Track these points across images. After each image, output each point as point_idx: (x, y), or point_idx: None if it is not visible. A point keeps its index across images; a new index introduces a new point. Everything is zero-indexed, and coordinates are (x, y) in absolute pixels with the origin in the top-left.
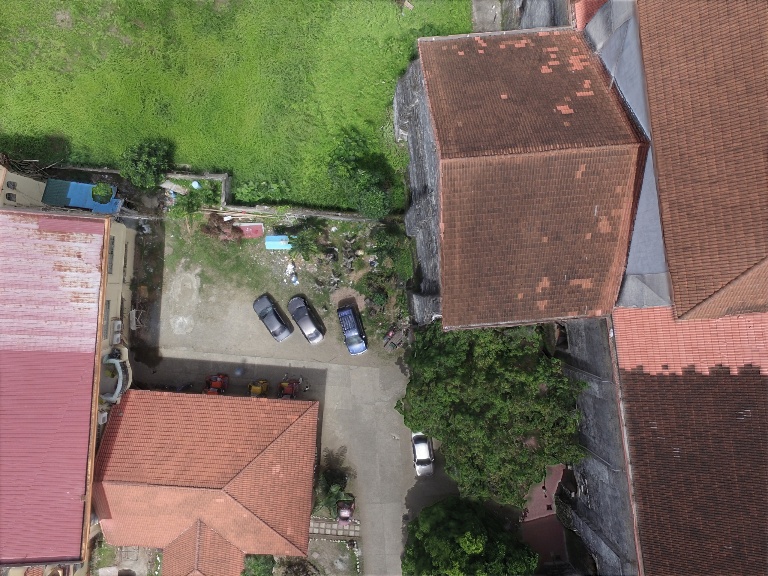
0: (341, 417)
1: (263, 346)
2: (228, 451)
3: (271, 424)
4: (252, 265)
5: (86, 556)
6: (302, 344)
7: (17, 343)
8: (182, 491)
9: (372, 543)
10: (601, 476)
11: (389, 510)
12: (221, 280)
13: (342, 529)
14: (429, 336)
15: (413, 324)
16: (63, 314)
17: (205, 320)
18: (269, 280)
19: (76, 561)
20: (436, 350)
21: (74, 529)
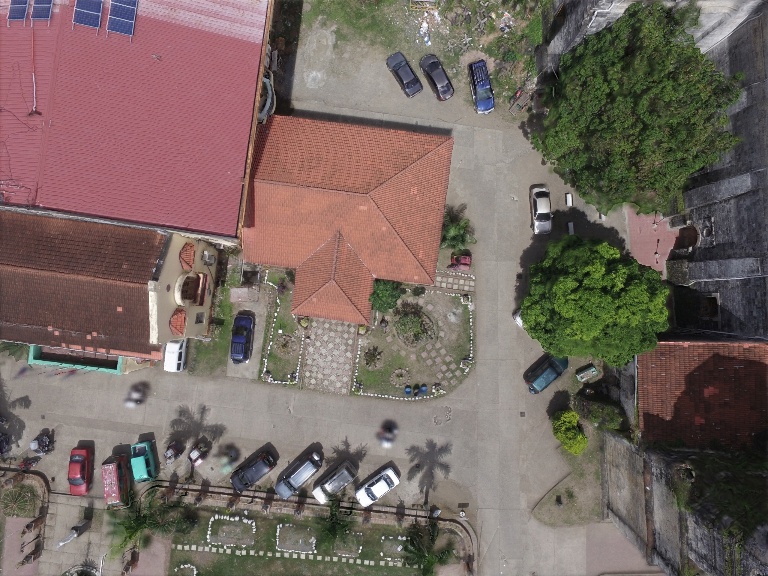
0: (463, 176)
1: (392, 103)
2: (371, 167)
3: (410, 150)
4: (386, 24)
5: (212, 289)
6: (430, 103)
7: (194, 21)
8: (329, 194)
9: (486, 299)
10: (740, 189)
11: (504, 268)
12: (355, 38)
13: (457, 283)
14: (579, 51)
15: (545, 78)
16: (236, 1)
17: (337, 75)
18: (402, 40)
19: (233, 238)
20: (590, 56)
21: (232, 209)
